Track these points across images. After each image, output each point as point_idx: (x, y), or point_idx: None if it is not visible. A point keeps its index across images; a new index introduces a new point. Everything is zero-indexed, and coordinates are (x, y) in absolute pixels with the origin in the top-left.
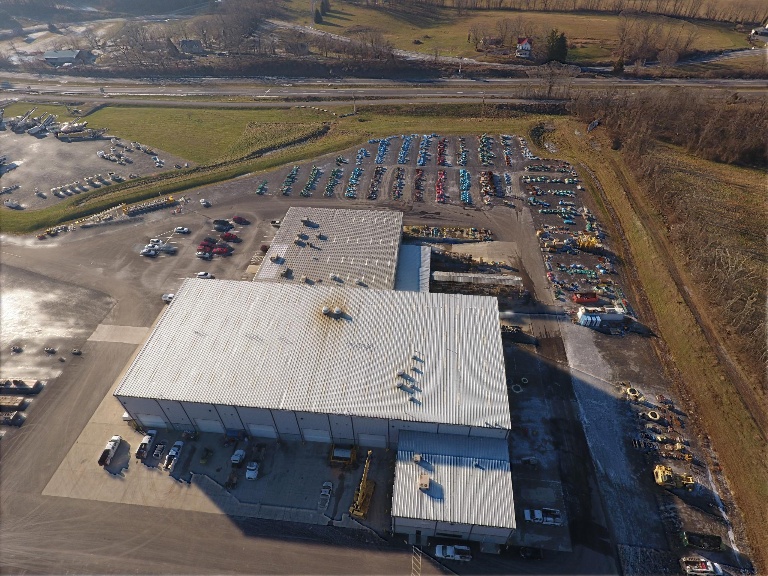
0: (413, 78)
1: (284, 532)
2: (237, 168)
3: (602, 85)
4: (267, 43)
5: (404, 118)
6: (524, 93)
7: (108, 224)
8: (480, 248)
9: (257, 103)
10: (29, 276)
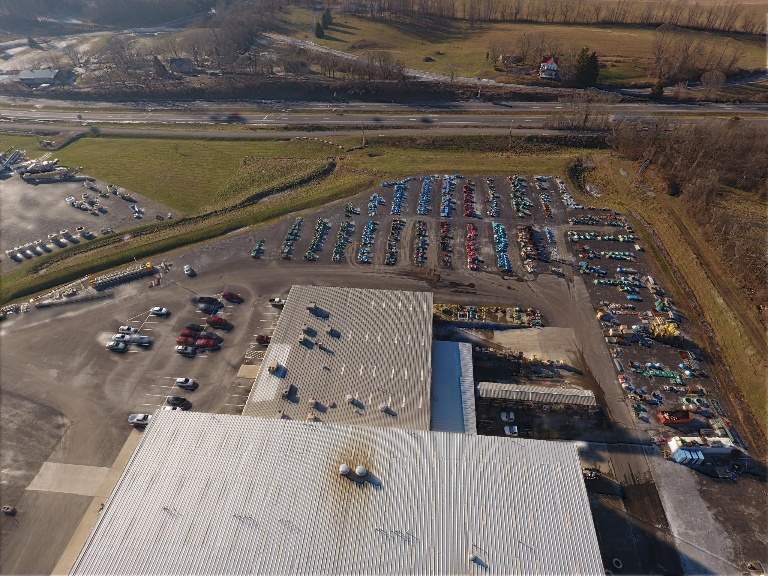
0: (427, 102)
1: None
2: (229, 221)
3: (641, 111)
4: (264, 62)
5: (420, 152)
6: (556, 123)
7: (70, 302)
8: (529, 337)
9: (253, 133)
10: None
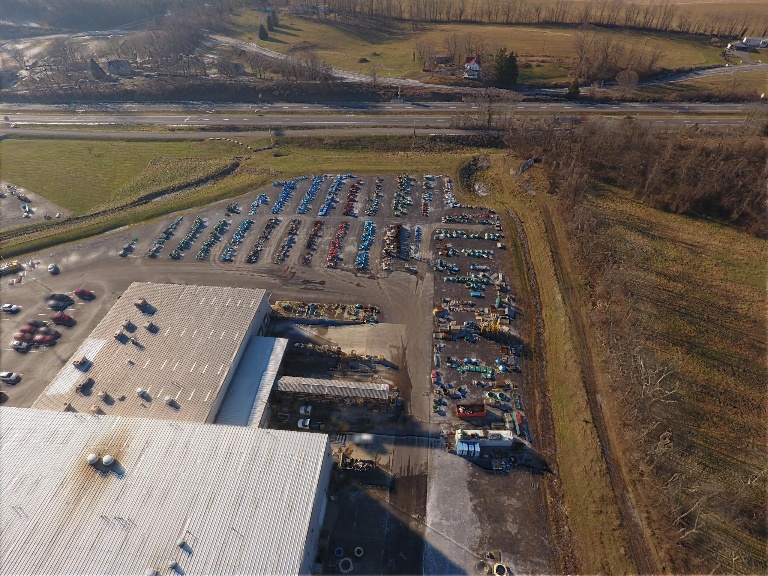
0: (349, 103)
1: None
2: (110, 220)
3: (553, 111)
4: (197, 64)
5: (325, 152)
6: (461, 122)
7: None
8: (360, 333)
9: (170, 134)
10: None
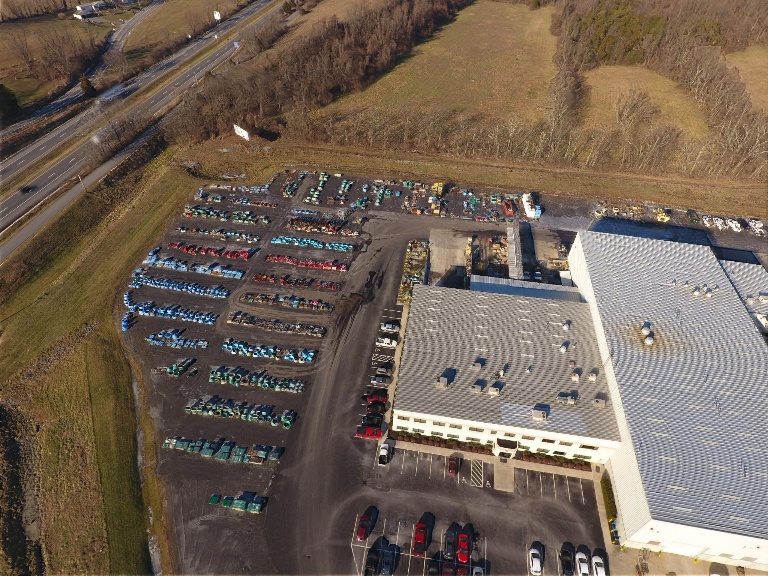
0: None
1: None
2: None
3: None
4: None
5: (37, 284)
6: (98, 155)
7: None
8: (441, 252)
9: None
10: None
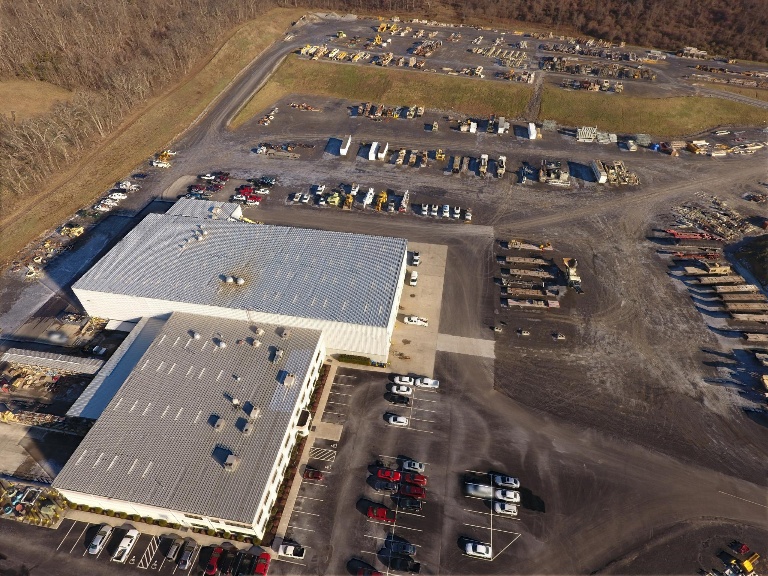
0: None
1: (302, 227)
2: None
3: None
4: None
5: None
6: None
7: None
8: None
9: None
10: (657, 444)
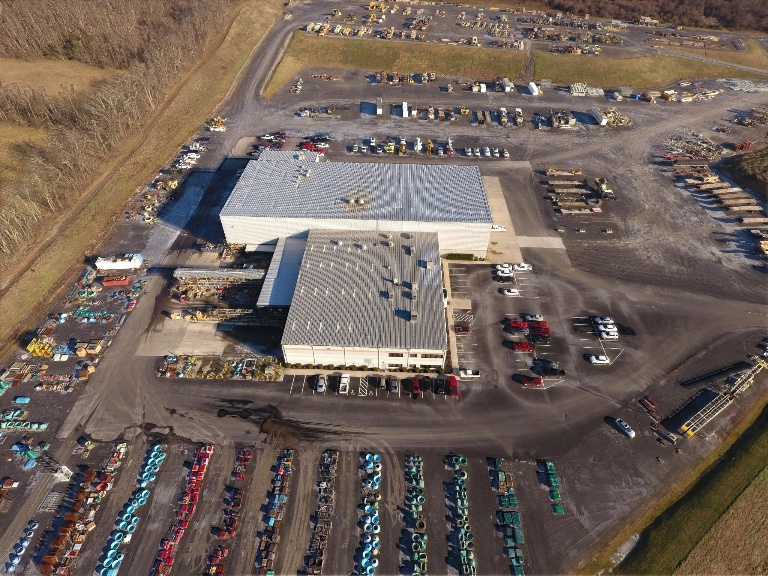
0: None
1: None
2: None
3: None
4: None
5: None
6: None
7: (719, 371)
8: (189, 344)
9: None
10: (699, 290)
